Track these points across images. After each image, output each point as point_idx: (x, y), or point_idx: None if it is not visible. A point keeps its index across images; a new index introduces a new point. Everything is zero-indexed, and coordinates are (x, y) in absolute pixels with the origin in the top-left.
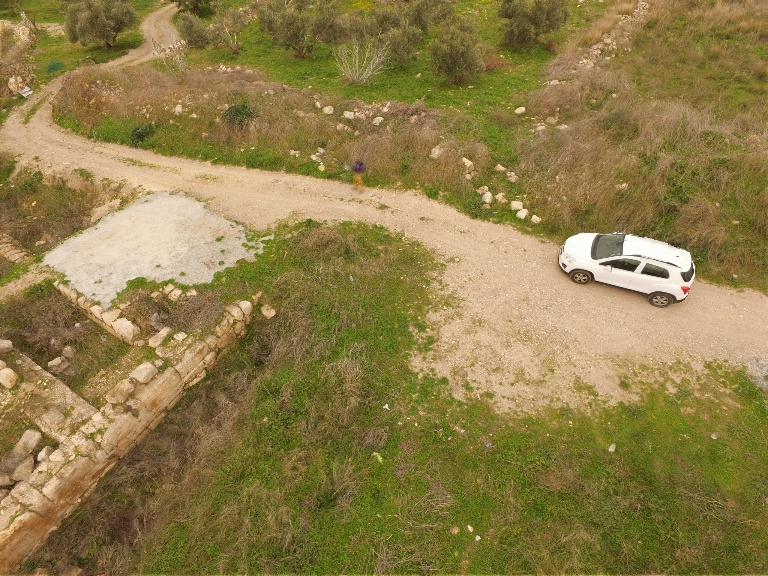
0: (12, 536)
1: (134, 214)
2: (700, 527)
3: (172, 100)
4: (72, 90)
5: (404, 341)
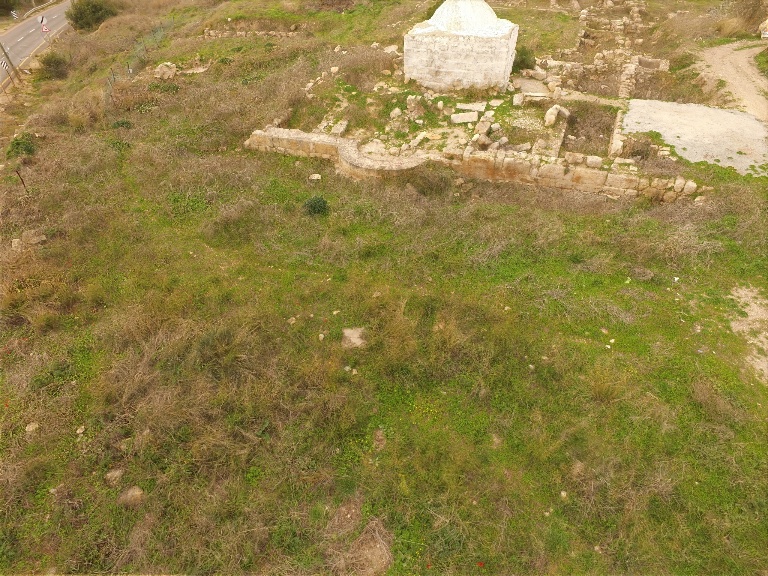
0: (482, 161)
1: (712, 112)
2: (767, 560)
3: None
4: None
5: (760, 279)
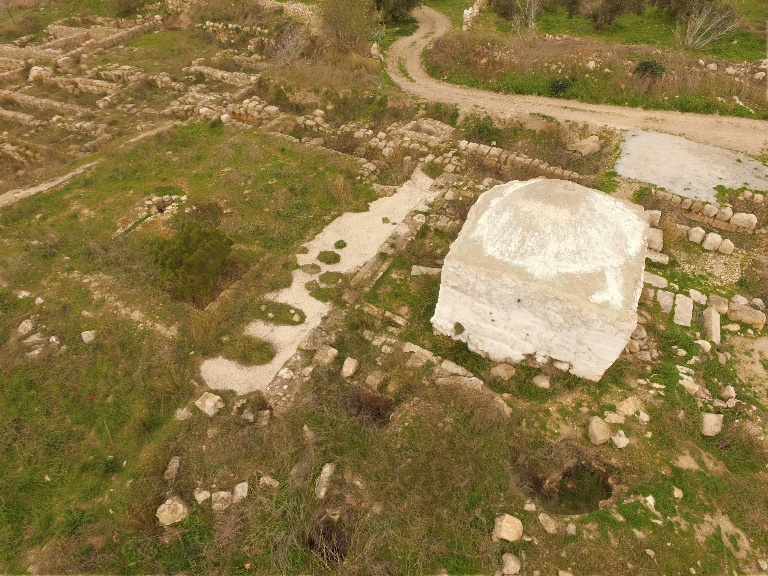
0: None
1: (641, 144)
2: None
3: (583, 57)
4: (454, 52)
5: None
